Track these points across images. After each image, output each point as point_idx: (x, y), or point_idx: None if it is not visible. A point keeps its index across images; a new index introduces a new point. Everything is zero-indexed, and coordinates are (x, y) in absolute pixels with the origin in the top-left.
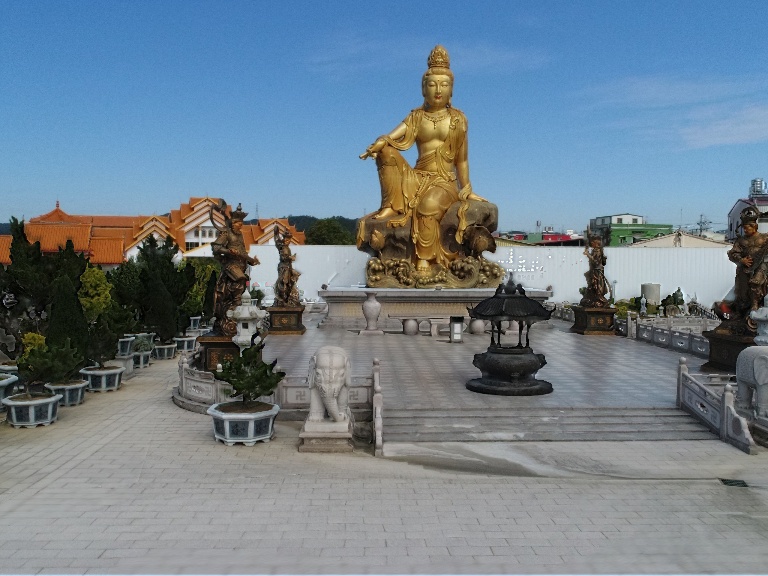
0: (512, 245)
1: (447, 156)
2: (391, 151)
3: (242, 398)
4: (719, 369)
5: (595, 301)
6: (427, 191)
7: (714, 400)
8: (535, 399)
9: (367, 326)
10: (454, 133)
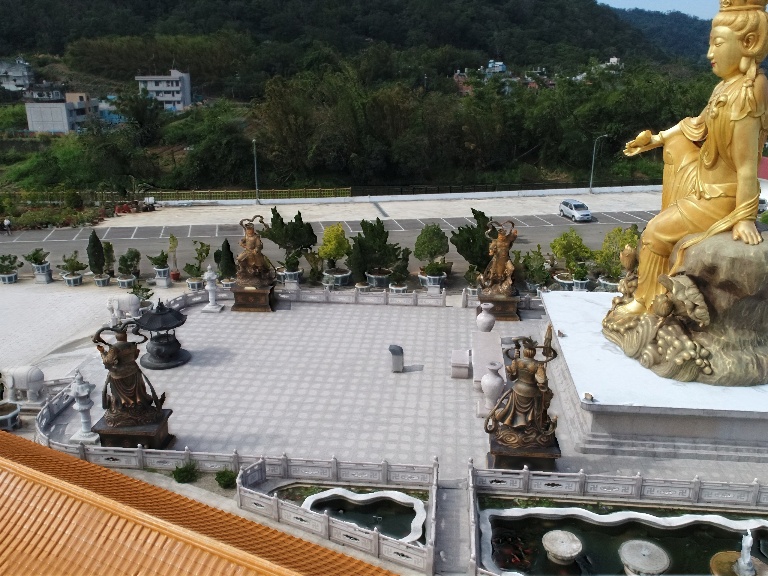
0: None
1: (705, 159)
2: (671, 143)
3: (177, 306)
4: None
5: None
6: None
7: None
8: None
9: None
10: (716, 123)
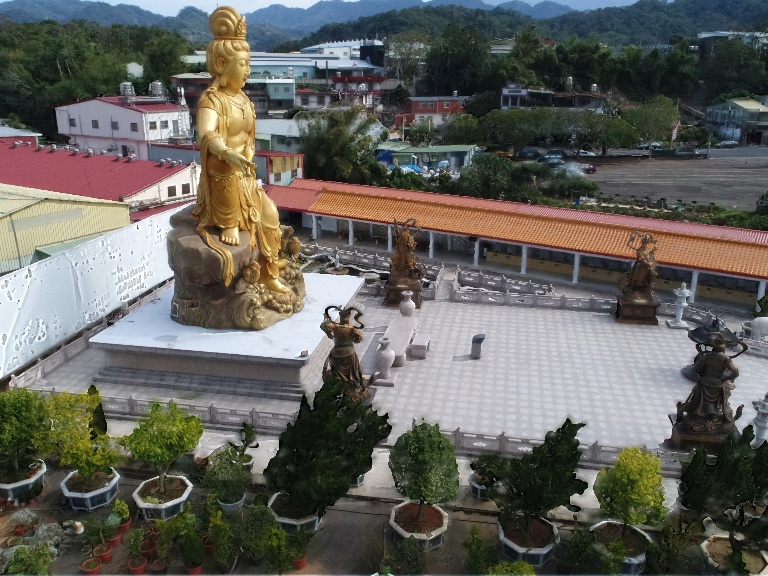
0: (98, 207)
1: None
2: None
3: None
4: (638, 320)
5: (417, 280)
6: (262, 199)
7: (765, 346)
8: (740, 376)
9: (386, 375)
10: None
